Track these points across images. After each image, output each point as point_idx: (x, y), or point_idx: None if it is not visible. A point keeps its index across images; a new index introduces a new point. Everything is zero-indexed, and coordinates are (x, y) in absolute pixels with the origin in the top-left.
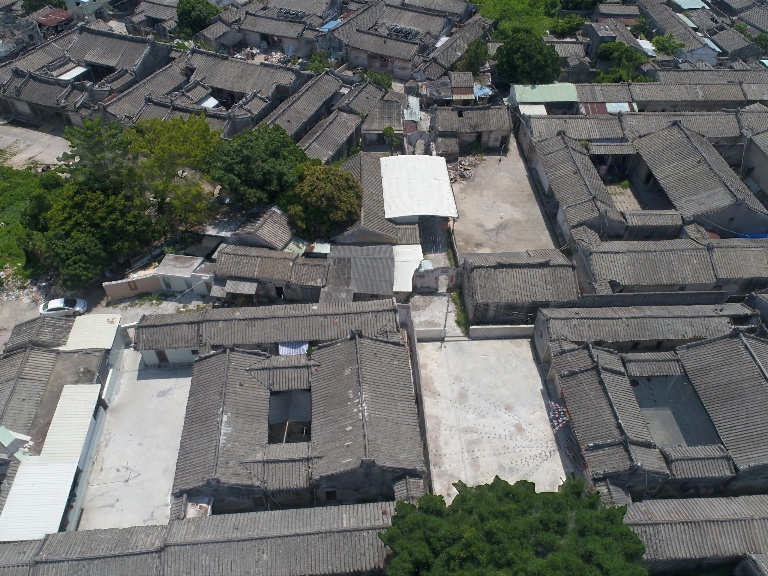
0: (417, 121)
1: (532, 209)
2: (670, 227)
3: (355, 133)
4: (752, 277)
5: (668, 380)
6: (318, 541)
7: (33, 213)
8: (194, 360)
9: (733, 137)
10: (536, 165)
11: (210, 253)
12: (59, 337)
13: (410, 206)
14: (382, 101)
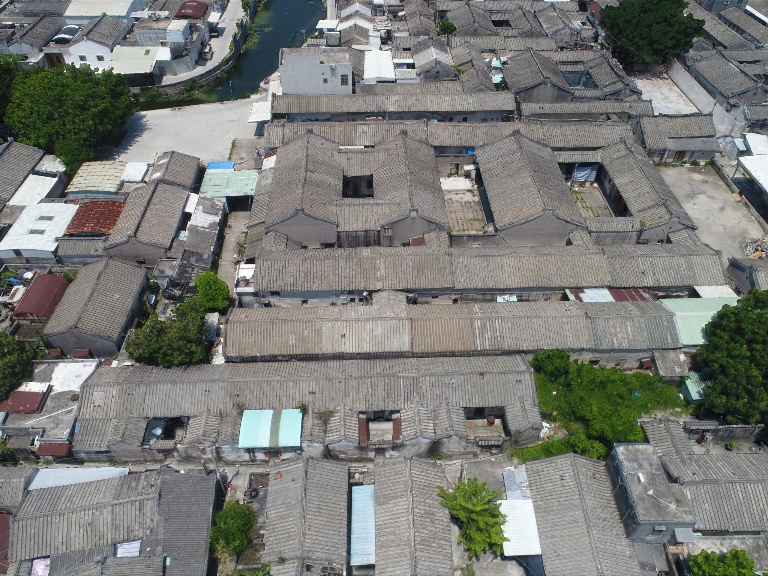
0: None
1: None
2: None
3: None
4: None
5: None
6: None
7: None
8: None
9: None
10: None
11: None
12: None
13: None
14: None
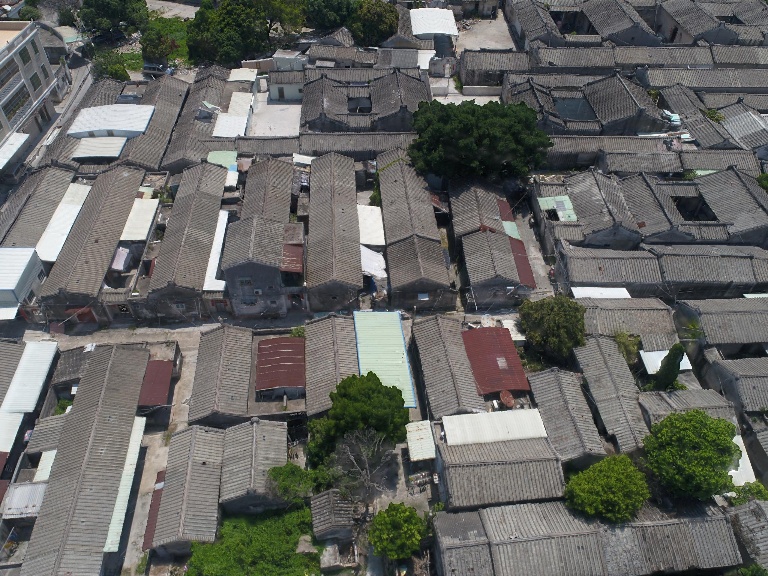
0: None
1: (509, 44)
2: (594, 44)
3: (392, 2)
4: (638, 63)
5: (575, 100)
6: (378, 137)
7: (197, 23)
8: (304, 84)
9: (650, 7)
10: (514, 22)
11: (304, 51)
12: (225, 76)
13: (429, 29)
14: None
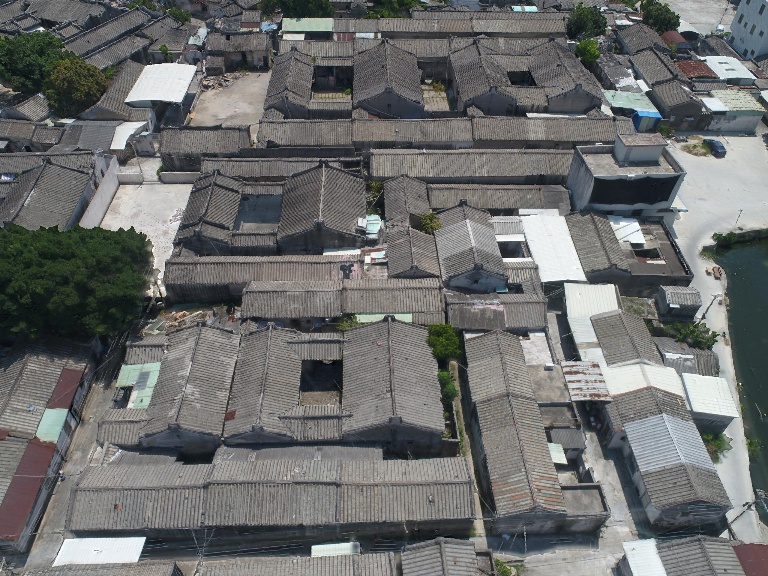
0: (199, 45)
1: None
2: (343, 112)
3: (143, 52)
4: (379, 141)
5: (271, 197)
6: None
7: None
8: None
9: (443, 57)
10: None
11: None
12: None
13: (146, 94)
14: (173, 29)
